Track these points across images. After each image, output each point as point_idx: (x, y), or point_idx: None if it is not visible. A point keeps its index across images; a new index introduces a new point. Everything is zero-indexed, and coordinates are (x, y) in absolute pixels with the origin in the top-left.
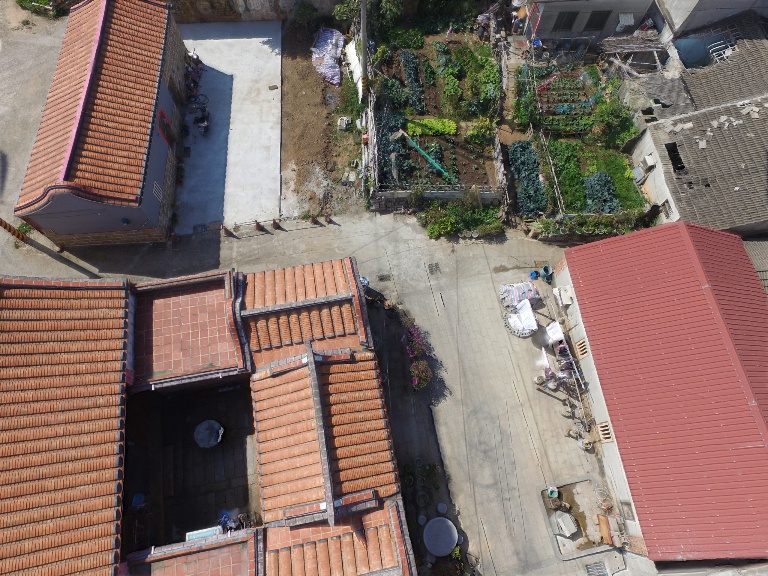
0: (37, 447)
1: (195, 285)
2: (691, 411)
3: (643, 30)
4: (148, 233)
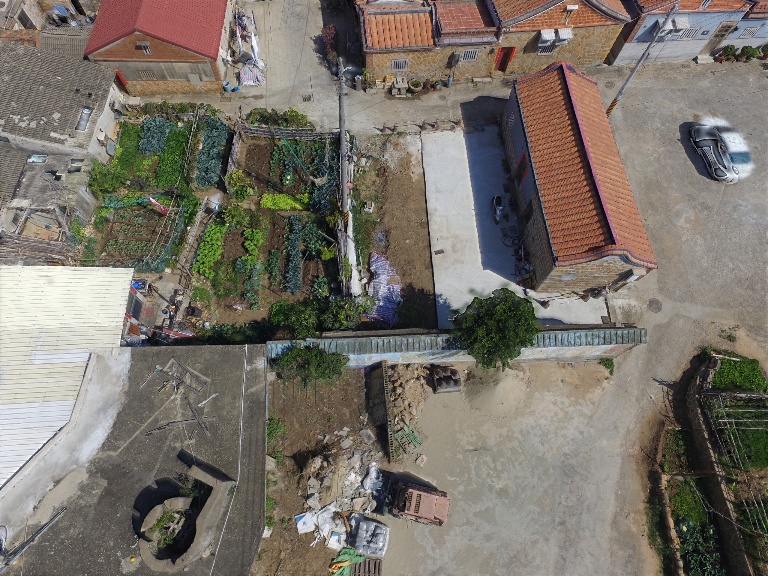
0: None
1: None
2: None
3: None
4: None
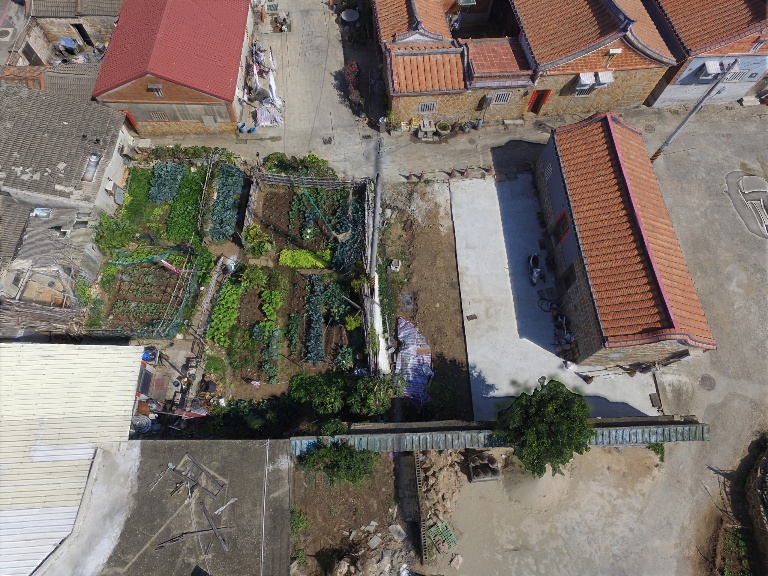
0: None
1: None
2: (204, 2)
3: (4, 341)
4: None
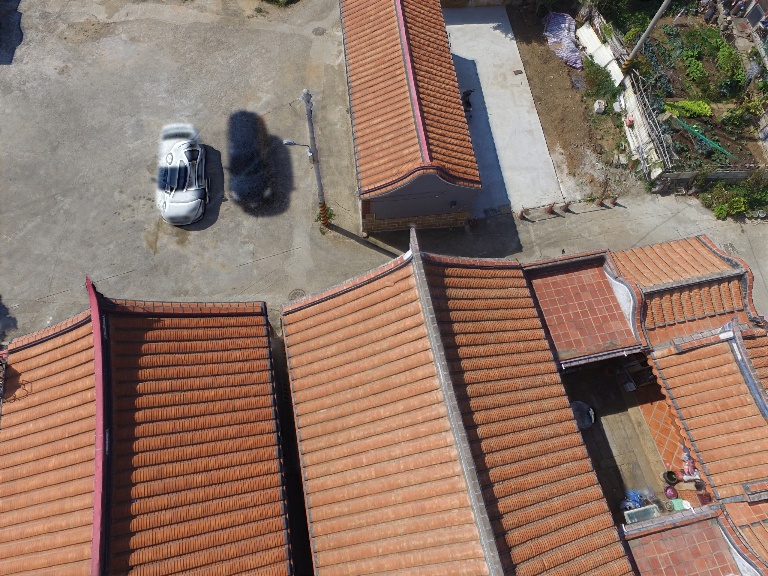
0: (520, 425)
1: (568, 265)
2: None
3: None
4: (456, 217)
